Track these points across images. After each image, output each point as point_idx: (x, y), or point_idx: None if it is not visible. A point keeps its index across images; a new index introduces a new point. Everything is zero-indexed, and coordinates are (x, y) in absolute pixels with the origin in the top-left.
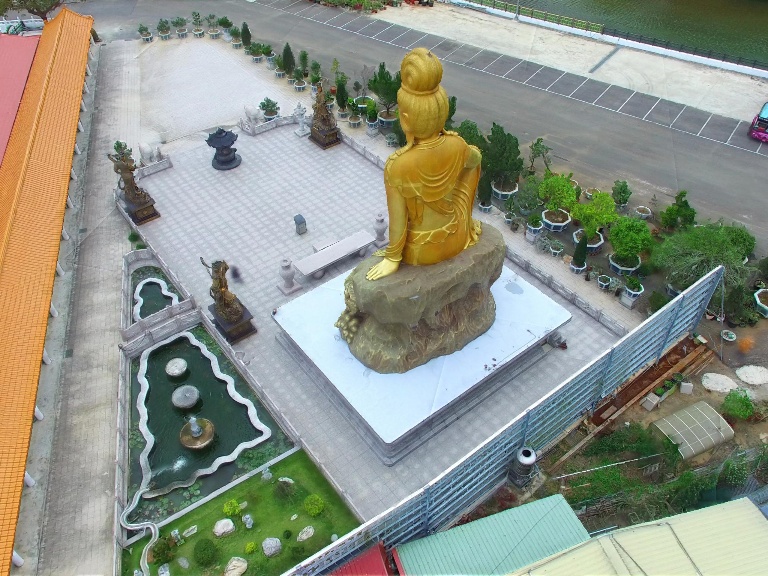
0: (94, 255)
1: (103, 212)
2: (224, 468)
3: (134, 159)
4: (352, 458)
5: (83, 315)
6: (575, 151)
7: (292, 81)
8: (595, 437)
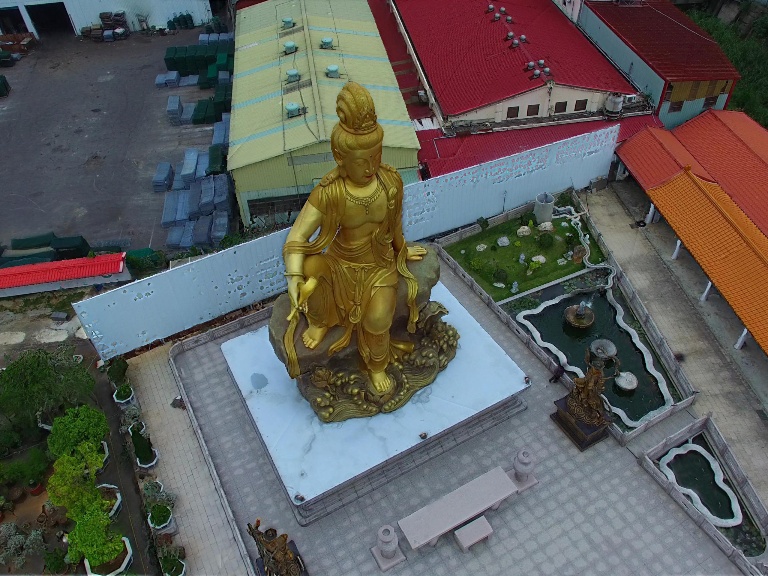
0: None
1: None
2: None
3: None
4: None
5: None
6: None
7: None
8: None
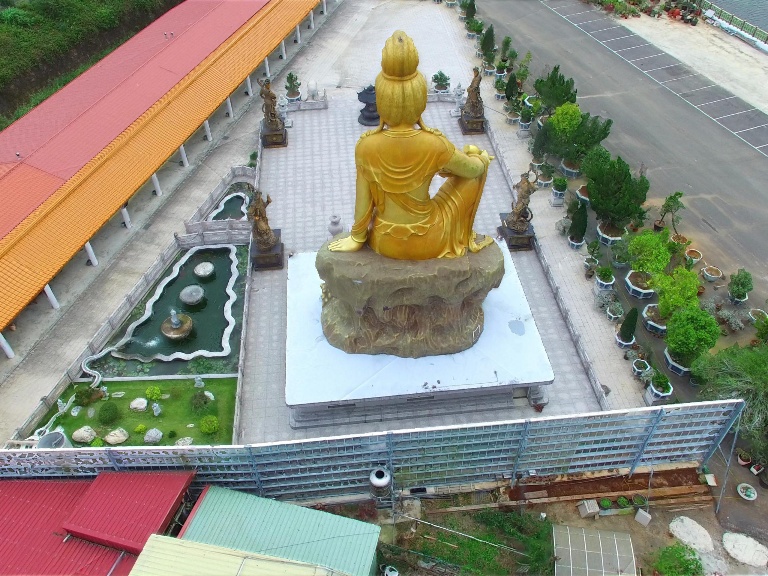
0: (218, 159)
1: (250, 128)
2: (179, 362)
3: (301, 93)
4: (270, 405)
5: (177, 202)
6: (734, 223)
7: (486, 63)
8: (500, 508)
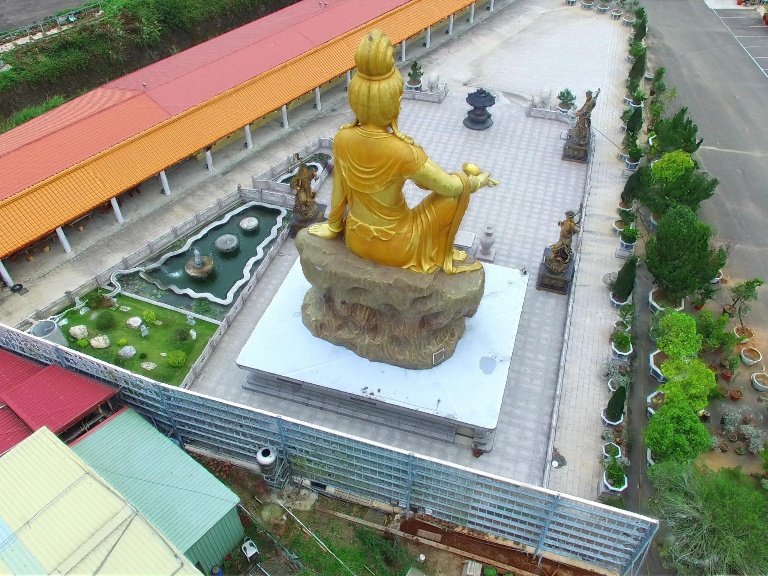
0: (316, 128)
1: None
2: (187, 298)
3: (422, 82)
4: None
5: (261, 158)
6: None
7: None
8: (385, 533)
